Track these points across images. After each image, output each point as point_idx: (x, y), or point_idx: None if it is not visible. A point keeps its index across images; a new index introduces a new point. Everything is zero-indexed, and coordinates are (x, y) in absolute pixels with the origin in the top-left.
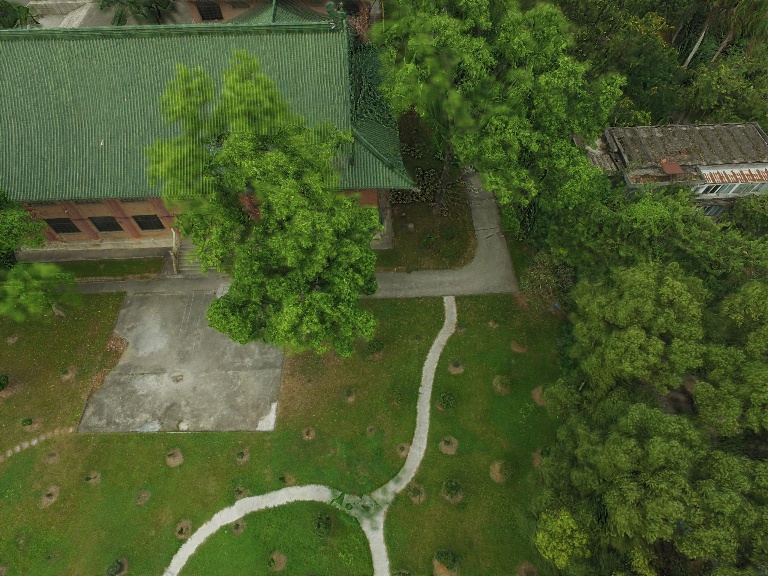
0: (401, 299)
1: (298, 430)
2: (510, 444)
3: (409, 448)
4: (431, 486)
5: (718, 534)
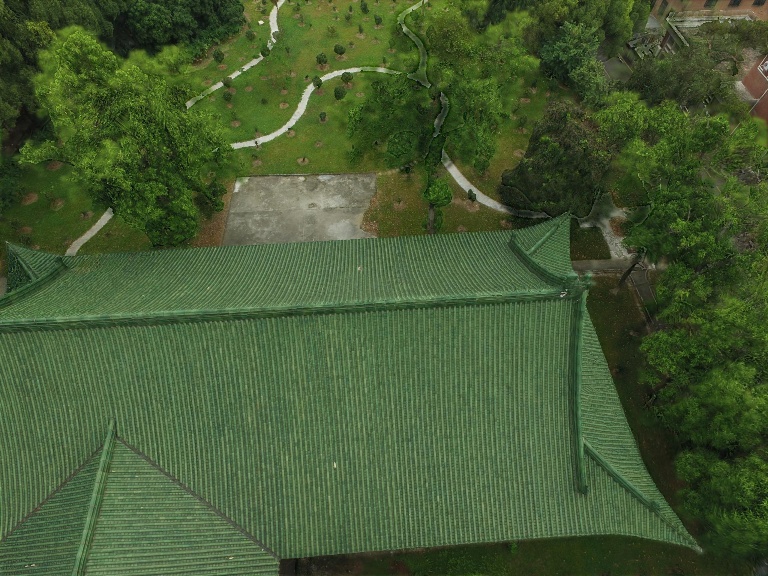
0: None
1: (219, 176)
2: None
3: None
4: None
5: None
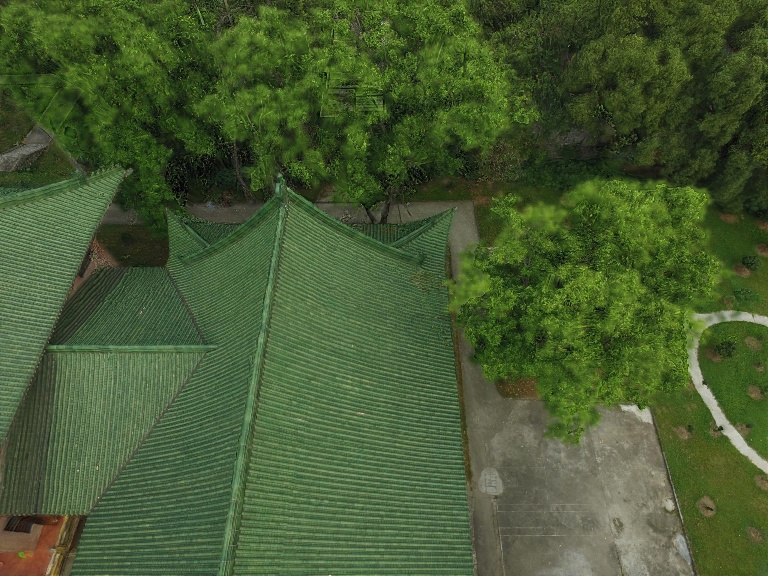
0: None
1: None
2: None
3: None
4: None
5: None
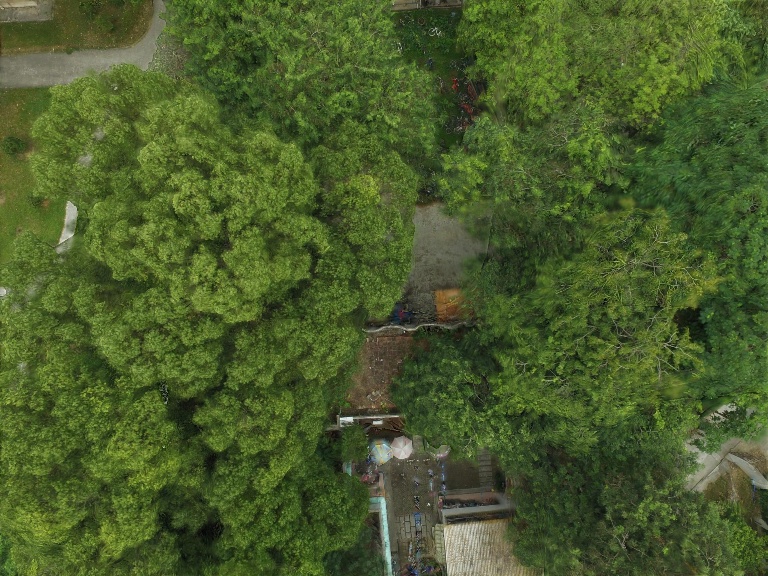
0: None
1: None
2: None
3: None
4: None
5: (13, 346)
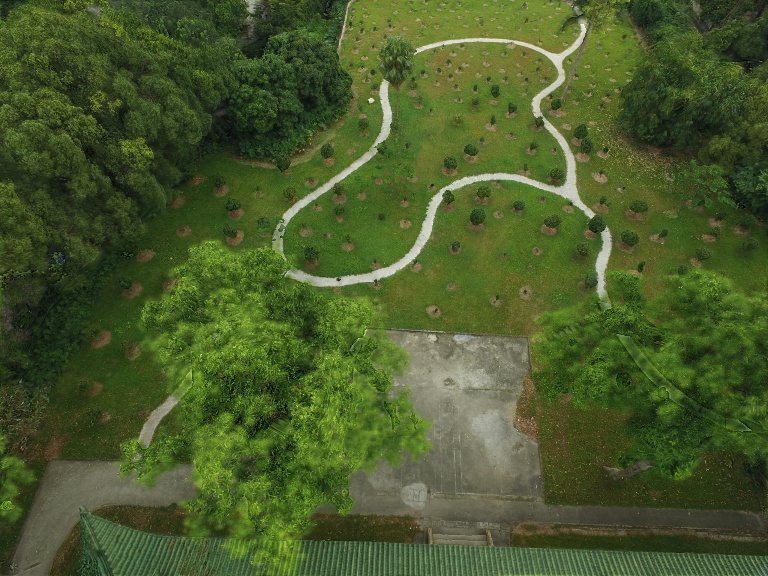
0: None
1: None
2: None
3: None
4: None
5: (42, 91)
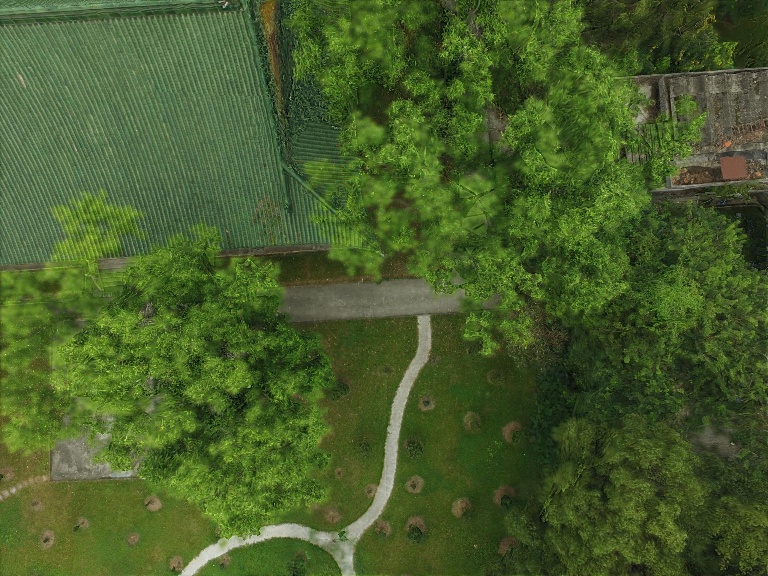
0: (369, 321)
1: None
2: (474, 482)
3: (376, 488)
4: (396, 523)
5: None
